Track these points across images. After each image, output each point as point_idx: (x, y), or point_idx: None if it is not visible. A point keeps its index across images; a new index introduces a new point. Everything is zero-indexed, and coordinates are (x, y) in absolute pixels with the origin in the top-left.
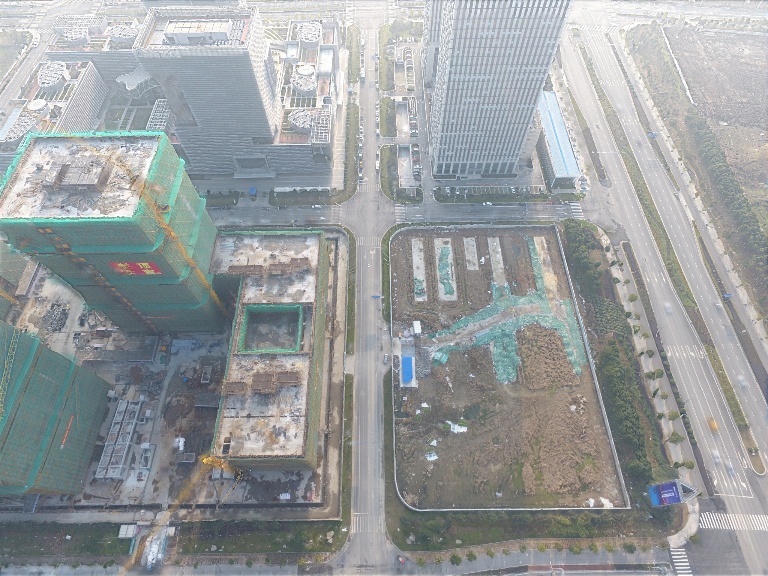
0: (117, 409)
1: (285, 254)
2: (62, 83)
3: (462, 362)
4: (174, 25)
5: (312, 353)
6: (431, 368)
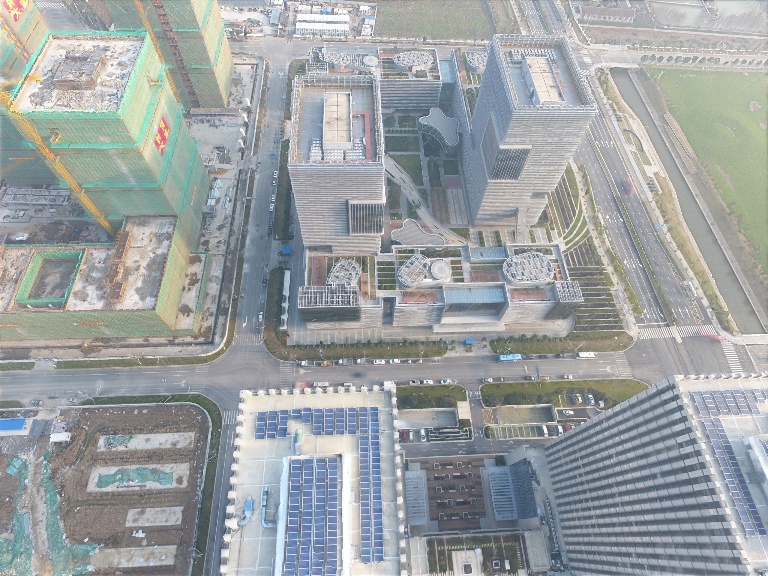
0: (62, 190)
1: (139, 279)
2: (405, 69)
3: (1, 493)
4: (343, 98)
5: (4, 313)
6: (8, 454)
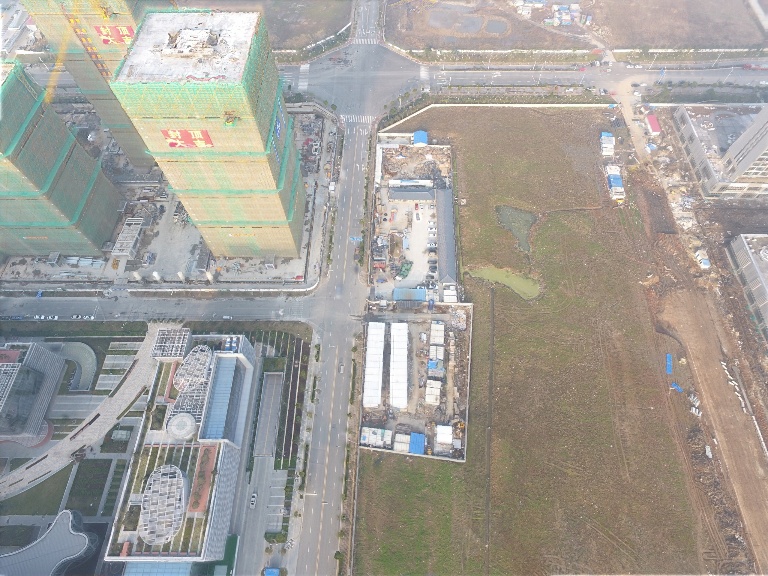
0: None
1: None
2: None
3: None
4: None
5: None
6: None
